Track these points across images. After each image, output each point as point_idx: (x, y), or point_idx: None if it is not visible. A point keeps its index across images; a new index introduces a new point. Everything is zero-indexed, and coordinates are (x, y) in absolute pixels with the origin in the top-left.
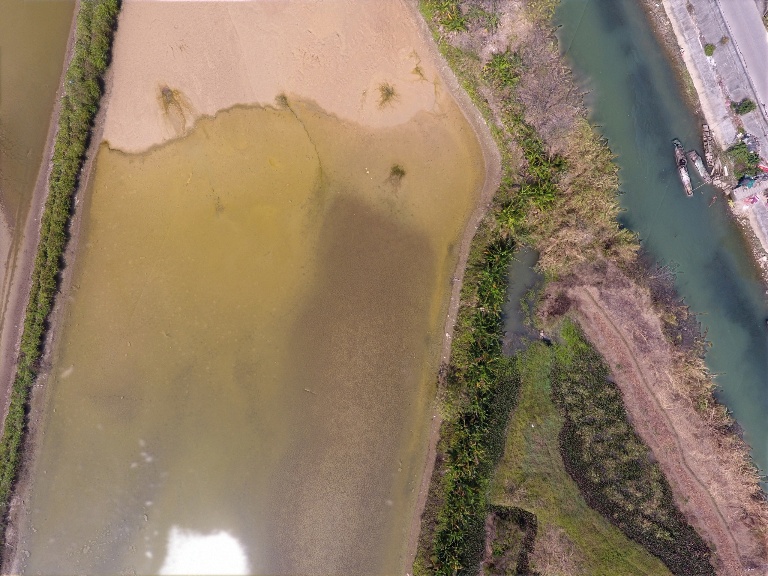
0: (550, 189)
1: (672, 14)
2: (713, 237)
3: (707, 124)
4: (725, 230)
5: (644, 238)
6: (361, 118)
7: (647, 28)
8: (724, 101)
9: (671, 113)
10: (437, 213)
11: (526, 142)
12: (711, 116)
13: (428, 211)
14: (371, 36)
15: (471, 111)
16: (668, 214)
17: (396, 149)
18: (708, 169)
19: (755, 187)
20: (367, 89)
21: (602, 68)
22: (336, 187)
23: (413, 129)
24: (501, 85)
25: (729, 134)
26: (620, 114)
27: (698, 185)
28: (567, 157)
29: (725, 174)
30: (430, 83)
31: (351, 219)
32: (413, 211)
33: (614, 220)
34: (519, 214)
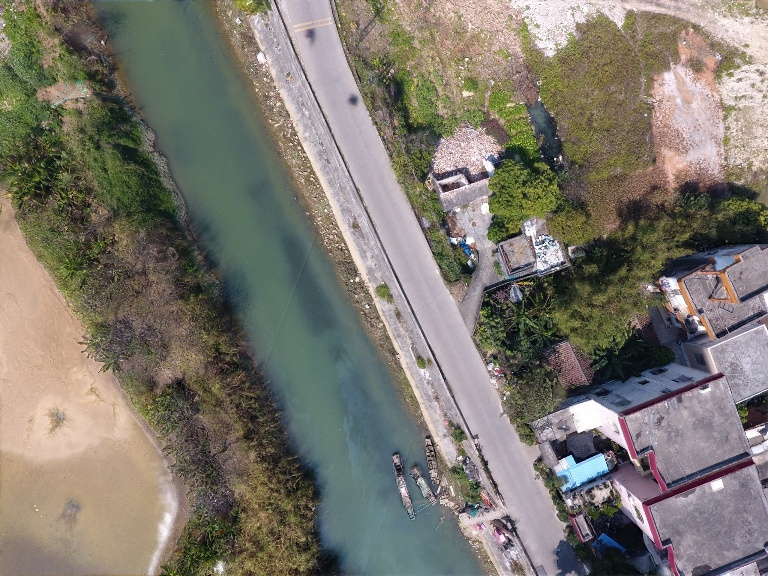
0: (219, 552)
1: (384, 317)
2: (442, 563)
3: (431, 436)
4: (455, 554)
5: (361, 568)
6: (27, 449)
7: (360, 329)
8: (442, 418)
9: (391, 423)
10: (120, 551)
11: (198, 490)
12: (433, 429)
13: (109, 549)
14: (37, 355)
15: (156, 434)
16: (388, 540)
17: (69, 482)
18: (434, 487)
19: (479, 517)
20: (34, 416)
21: (309, 376)
22: (0, 528)
23: (89, 458)
24: (165, 429)
25: (451, 453)
26: (330, 429)
27: (420, 508)
28: (243, 509)
29: (452, 494)
30: (108, 405)
31: (19, 564)
32: (91, 550)
33: (313, 564)
34: (194, 571)
